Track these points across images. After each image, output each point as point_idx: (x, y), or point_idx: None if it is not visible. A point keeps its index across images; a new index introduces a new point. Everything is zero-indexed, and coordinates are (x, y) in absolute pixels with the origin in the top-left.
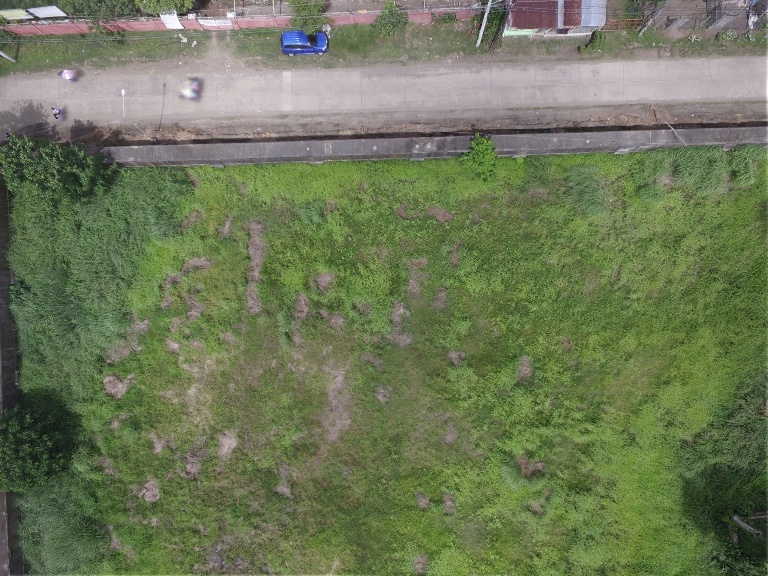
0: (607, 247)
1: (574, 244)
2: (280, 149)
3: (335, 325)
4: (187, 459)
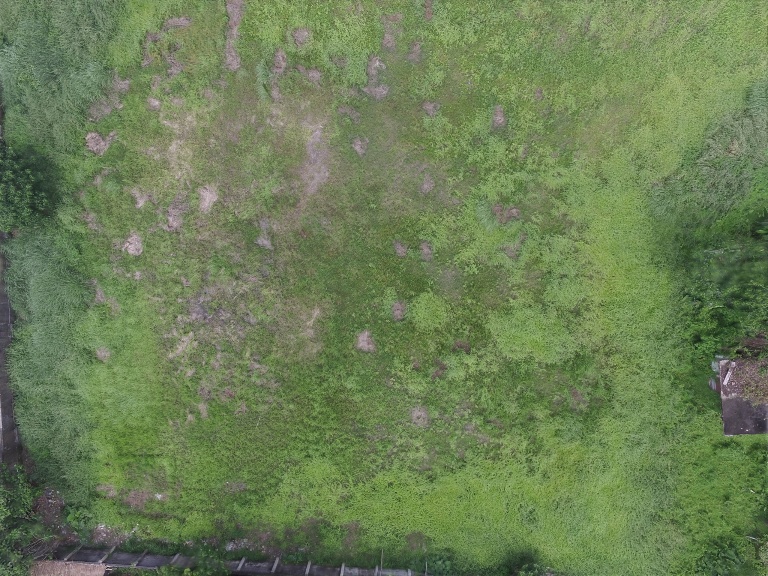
0: None
1: None
2: None
3: (312, 79)
4: (169, 213)
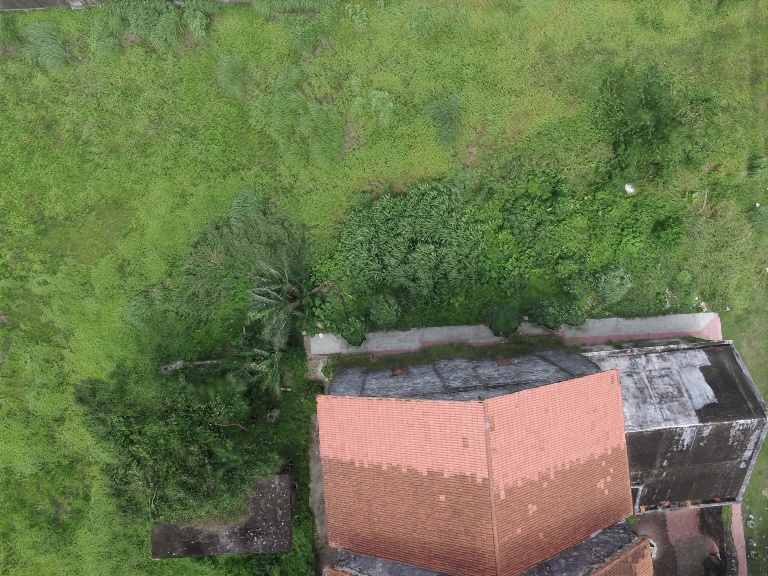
0: (71, 102)
1: (41, 100)
2: None
3: None
4: None
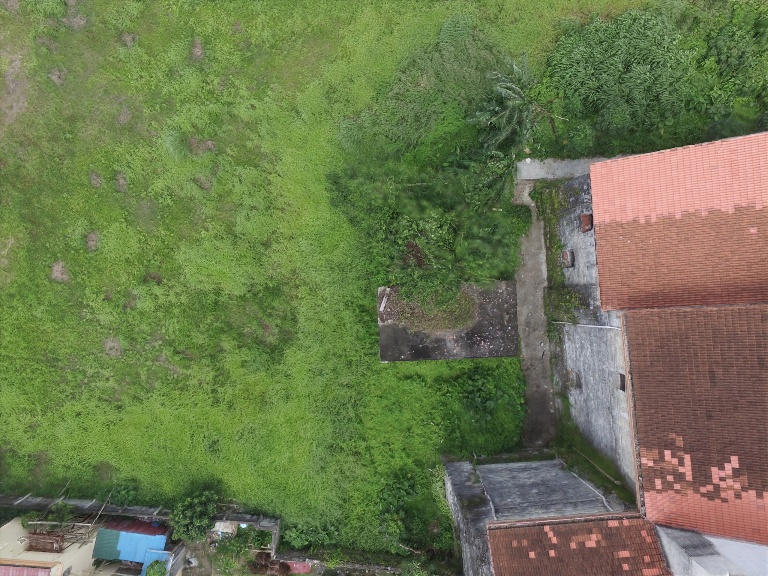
0: None
1: None
2: None
3: (11, 8)
4: None
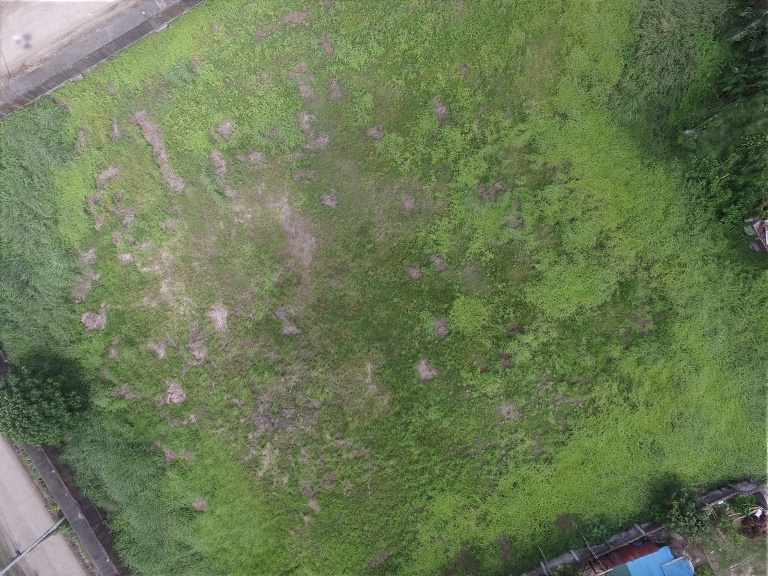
0: None
1: None
2: (119, 26)
3: (256, 162)
4: (191, 348)
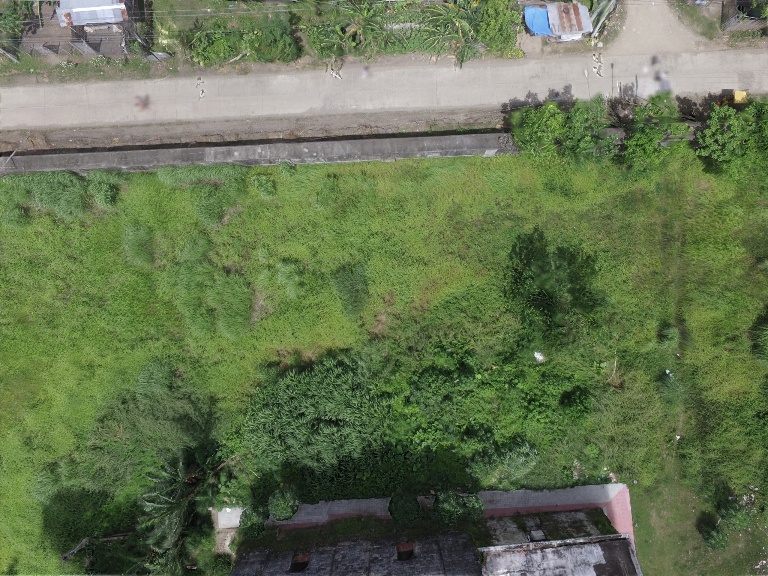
0: None
1: None
2: None
3: None
4: None
